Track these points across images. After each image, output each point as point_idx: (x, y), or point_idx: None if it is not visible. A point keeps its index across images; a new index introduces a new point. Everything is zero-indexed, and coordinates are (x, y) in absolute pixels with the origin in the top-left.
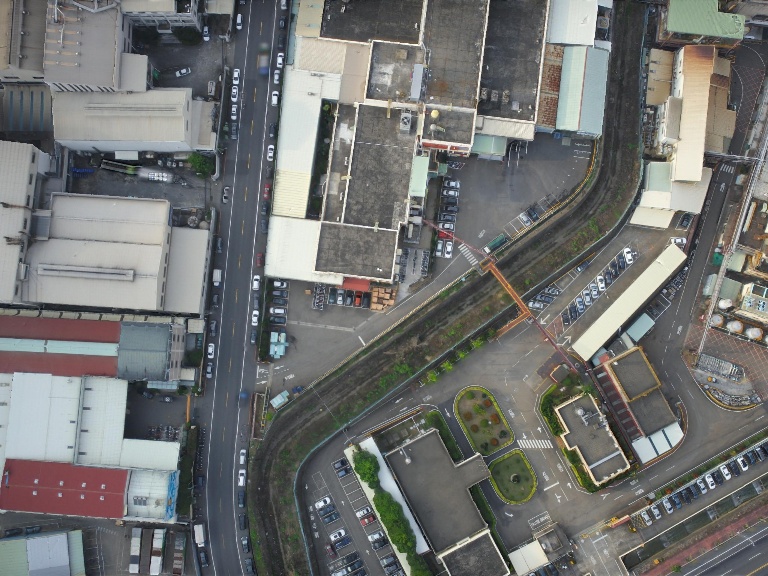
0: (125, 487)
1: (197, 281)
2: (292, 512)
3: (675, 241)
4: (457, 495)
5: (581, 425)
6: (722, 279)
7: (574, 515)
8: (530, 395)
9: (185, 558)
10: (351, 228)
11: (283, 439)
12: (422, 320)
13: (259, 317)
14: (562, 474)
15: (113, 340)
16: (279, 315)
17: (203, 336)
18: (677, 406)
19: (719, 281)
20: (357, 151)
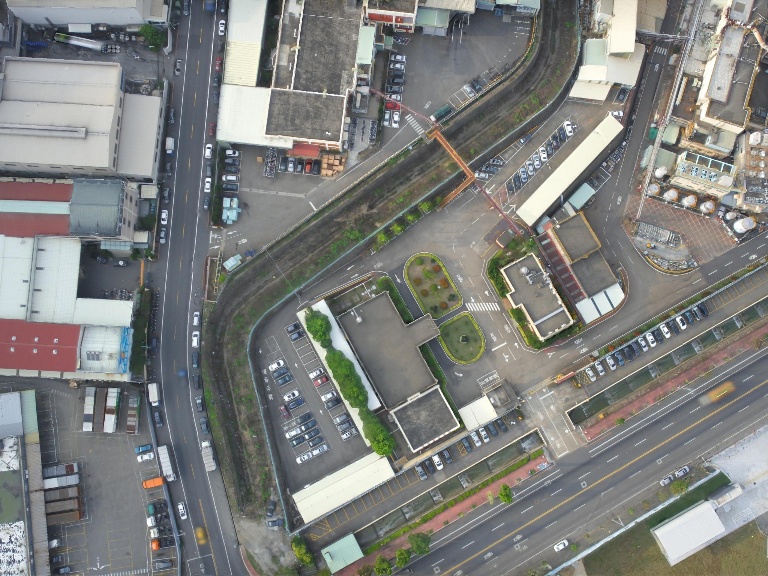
0: (78, 341)
1: (150, 145)
2: (246, 373)
3: (612, 114)
4: (407, 353)
5: (526, 284)
6: (657, 149)
7: (521, 373)
8: (477, 261)
9: (139, 418)
10: (300, 94)
11: (237, 306)
12: (371, 188)
13: (212, 184)
14: (509, 335)
15: (66, 200)
16: (231, 183)
17: (156, 202)
18: (618, 272)
19: (655, 151)
20: (306, 23)
